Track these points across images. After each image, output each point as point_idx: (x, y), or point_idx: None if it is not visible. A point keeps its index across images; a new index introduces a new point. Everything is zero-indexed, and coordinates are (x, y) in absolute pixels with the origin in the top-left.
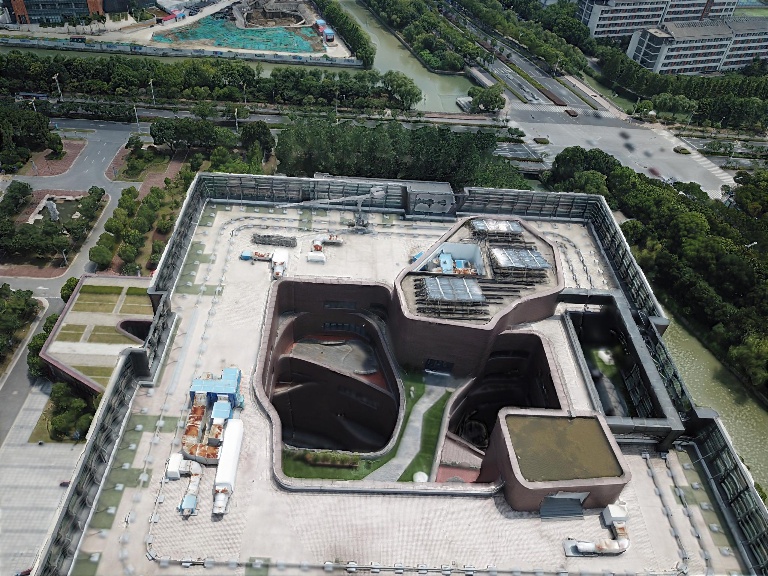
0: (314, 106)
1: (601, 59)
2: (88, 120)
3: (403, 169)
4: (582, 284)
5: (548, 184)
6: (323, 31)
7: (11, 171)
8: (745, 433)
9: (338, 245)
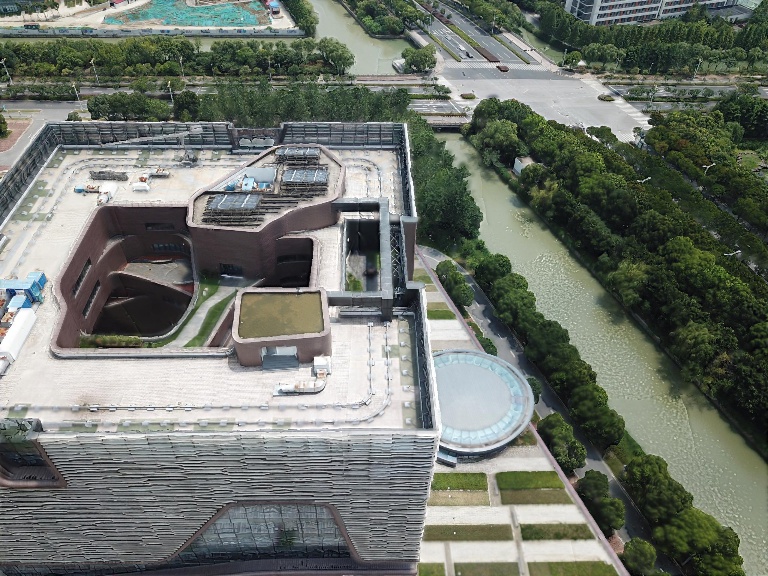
0: (249, 75)
1: (541, 15)
2: (35, 101)
3: None
4: None
5: (468, 136)
6: (269, 4)
7: None
8: (618, 351)
9: (165, 177)
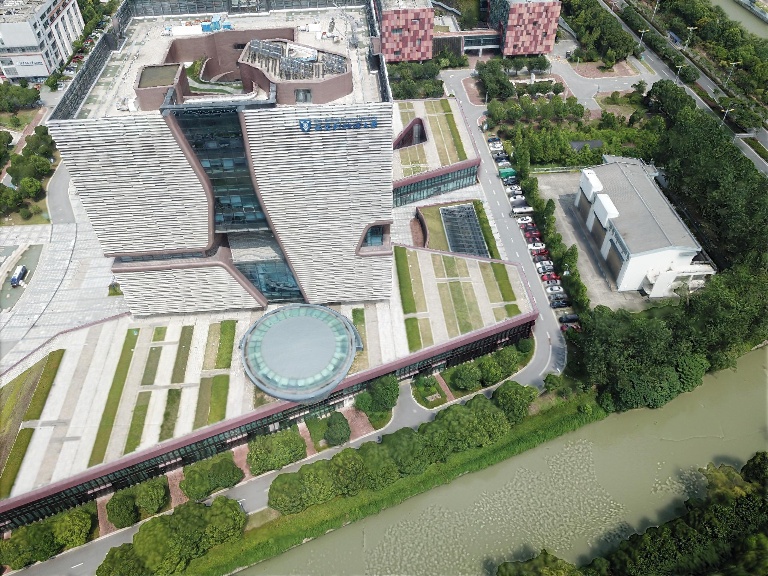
0: None
1: None
2: (668, 67)
3: None
4: None
5: None
6: None
7: (570, 60)
8: None
9: None
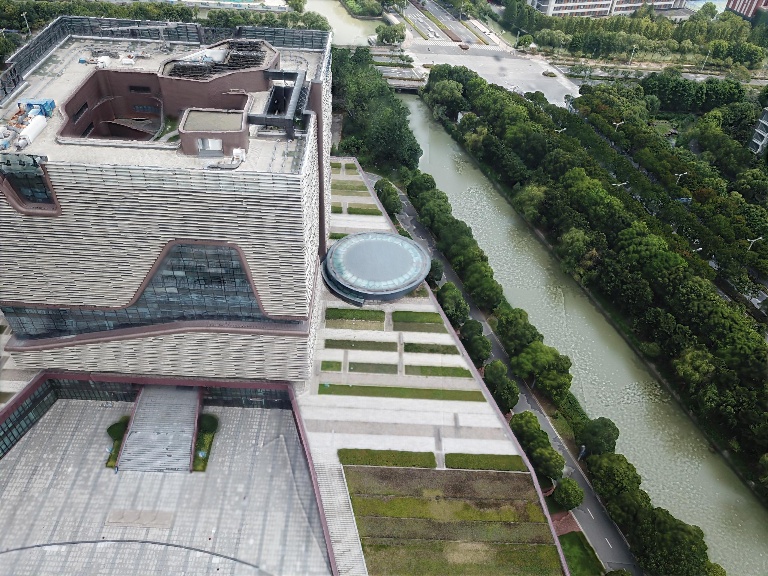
0: None
1: (506, 6)
2: None
3: None
4: None
5: None
6: None
7: None
8: (519, 256)
9: (147, 59)
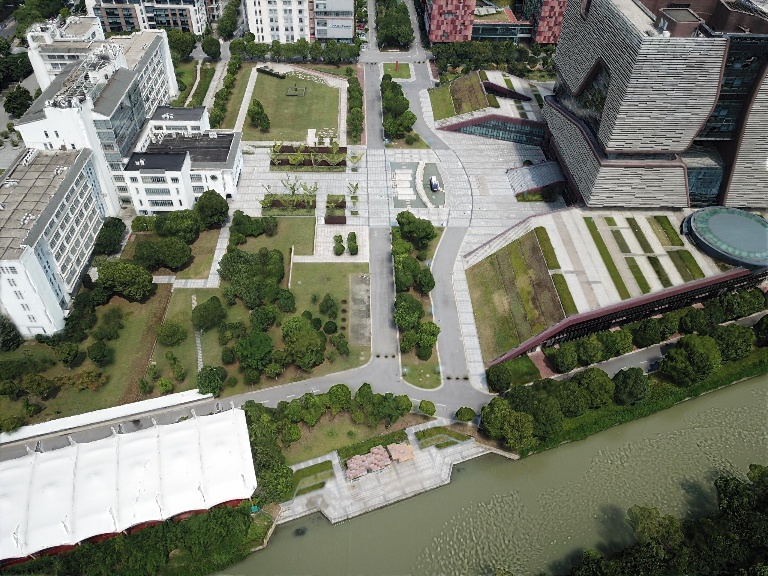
0: None
1: None
2: None
3: None
4: None
5: None
6: None
7: None
8: None
9: None
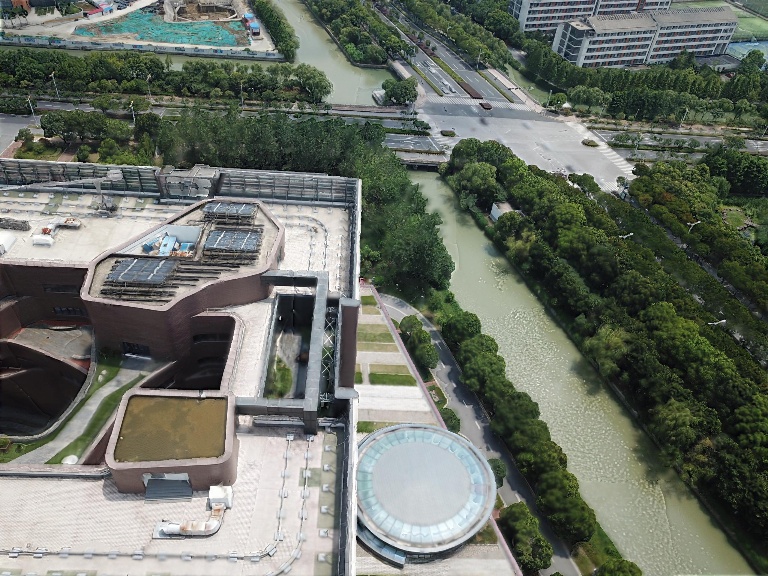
0: (220, 99)
1: (527, 52)
2: None
3: (289, 161)
4: (315, 267)
5: (445, 176)
6: (249, 25)
7: None
8: (592, 424)
9: (75, 229)
